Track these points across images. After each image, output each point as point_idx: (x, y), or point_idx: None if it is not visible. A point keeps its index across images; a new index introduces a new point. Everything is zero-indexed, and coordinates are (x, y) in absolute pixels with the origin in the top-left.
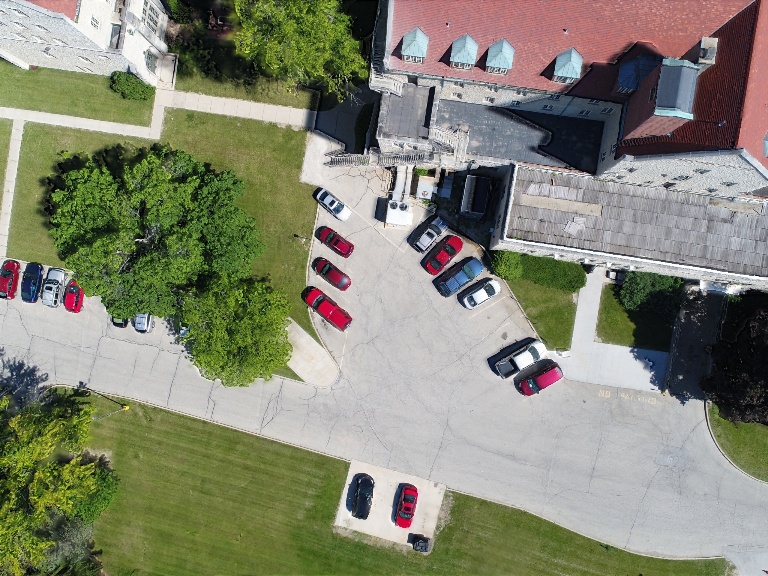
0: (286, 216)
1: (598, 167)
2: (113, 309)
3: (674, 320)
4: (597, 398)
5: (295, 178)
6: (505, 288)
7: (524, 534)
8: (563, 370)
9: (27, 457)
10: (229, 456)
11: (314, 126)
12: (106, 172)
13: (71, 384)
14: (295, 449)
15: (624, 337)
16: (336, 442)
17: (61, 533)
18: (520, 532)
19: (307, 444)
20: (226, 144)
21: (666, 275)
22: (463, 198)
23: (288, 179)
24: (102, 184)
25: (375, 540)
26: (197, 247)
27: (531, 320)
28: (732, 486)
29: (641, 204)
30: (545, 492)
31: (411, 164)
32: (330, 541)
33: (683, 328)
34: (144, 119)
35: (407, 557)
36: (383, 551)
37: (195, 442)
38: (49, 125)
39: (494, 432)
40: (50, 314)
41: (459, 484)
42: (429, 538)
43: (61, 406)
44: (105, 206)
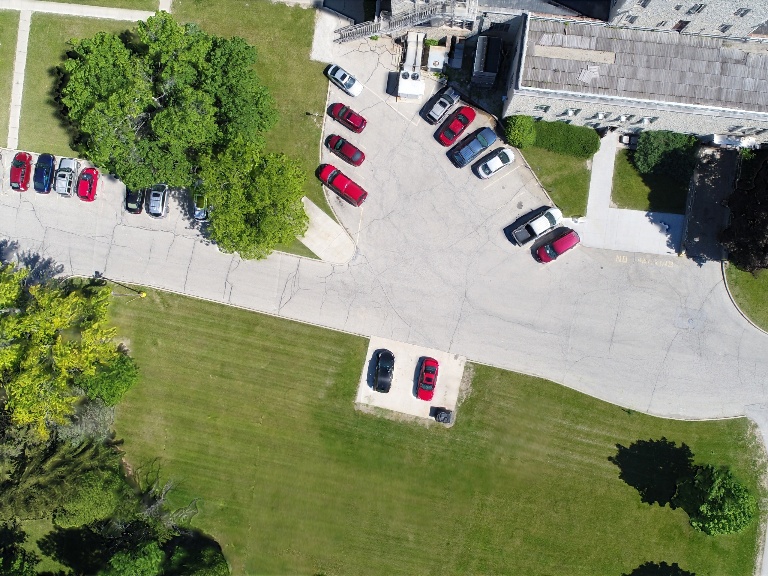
0: (297, 95)
1: (610, 13)
2: (129, 176)
3: (688, 182)
4: (614, 264)
5: (305, 56)
6: (519, 157)
7: (546, 402)
8: (579, 237)
9: (49, 318)
10: (248, 338)
11: (323, 3)
12: (118, 39)
13: (87, 274)
14: (314, 328)
15: (639, 201)
16: (355, 319)
17: (83, 411)
18: (542, 400)
19: (326, 322)
20: (235, 25)
21: (680, 133)
22: (475, 59)
23: (298, 57)
24: (115, 48)
25: (397, 415)
26: (212, 108)
27: (546, 188)
28: (752, 345)
29: (654, 50)
30: (565, 359)
31: (423, 20)
32: (352, 418)
33: (698, 191)
34: (152, 4)
35: (430, 431)
36: (405, 426)
37: (213, 326)
38: (56, 14)
39: (512, 302)
40: (64, 205)
41: (479, 355)
42: (451, 410)
43: (78, 296)
44: (118, 70)
